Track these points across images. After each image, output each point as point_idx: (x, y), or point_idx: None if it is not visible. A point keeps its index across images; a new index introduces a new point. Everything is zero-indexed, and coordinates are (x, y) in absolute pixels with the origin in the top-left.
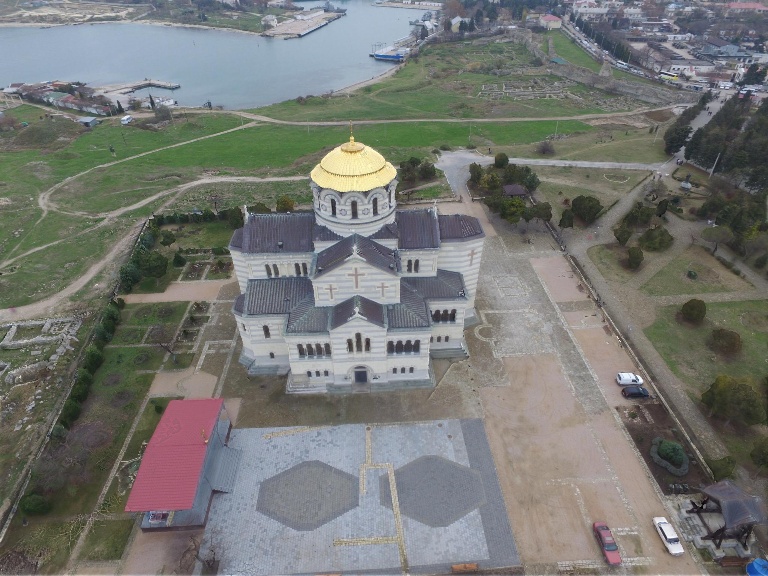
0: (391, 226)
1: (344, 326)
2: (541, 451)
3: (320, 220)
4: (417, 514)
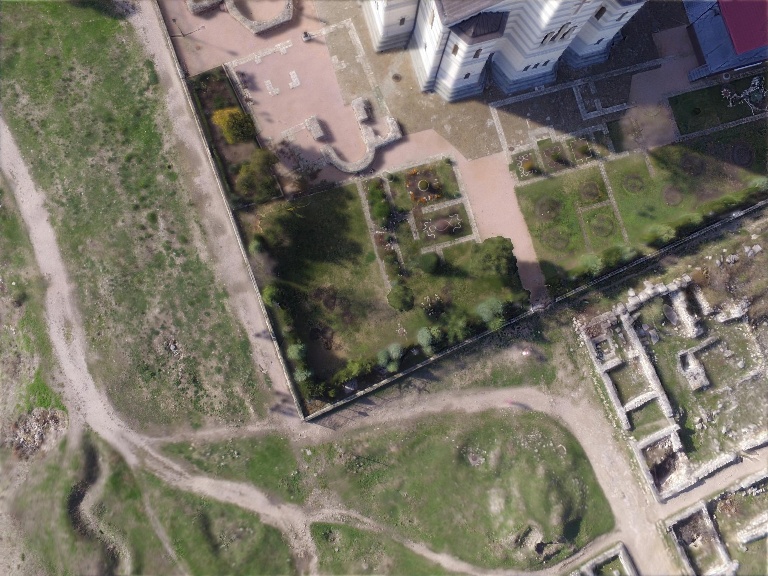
0: None
1: None
2: None
3: None
4: None
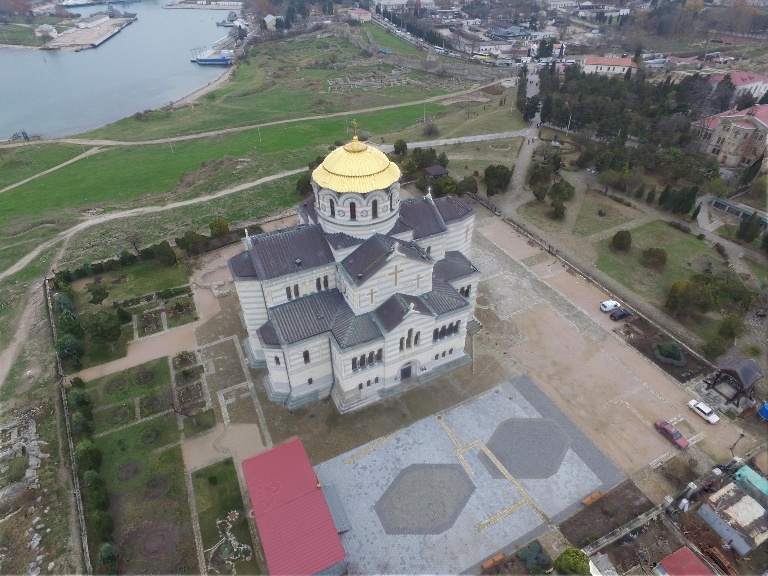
0: (401, 219)
1: (399, 326)
2: (584, 384)
3: (334, 228)
4: (528, 473)
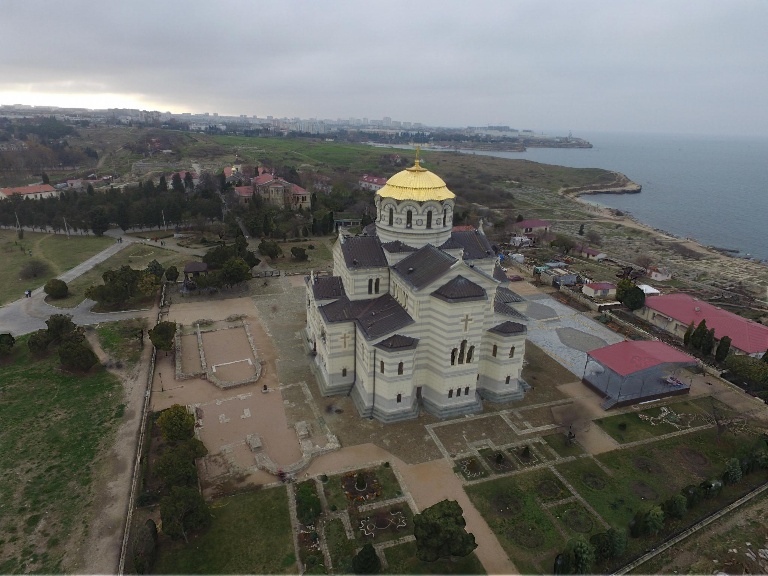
0: None
1: None
2: None
3: None
4: None
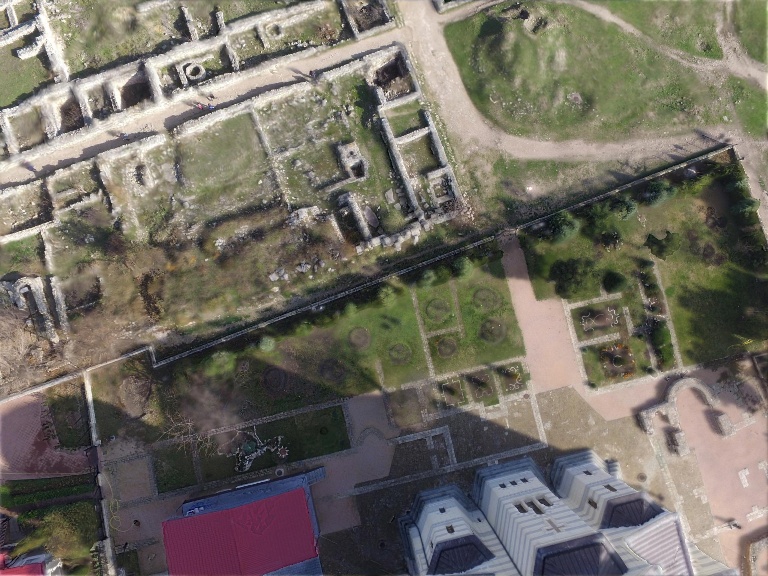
0: None
1: None
2: None
3: None
4: None
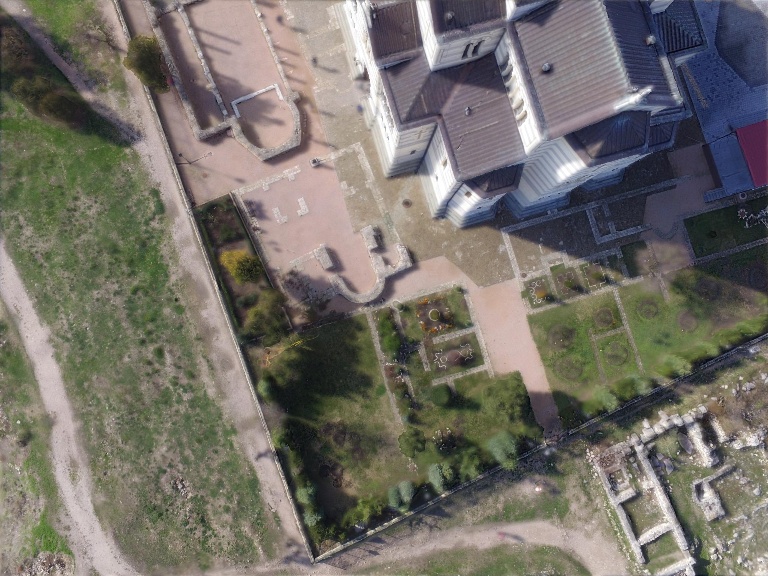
0: None
1: None
2: None
3: None
4: None
